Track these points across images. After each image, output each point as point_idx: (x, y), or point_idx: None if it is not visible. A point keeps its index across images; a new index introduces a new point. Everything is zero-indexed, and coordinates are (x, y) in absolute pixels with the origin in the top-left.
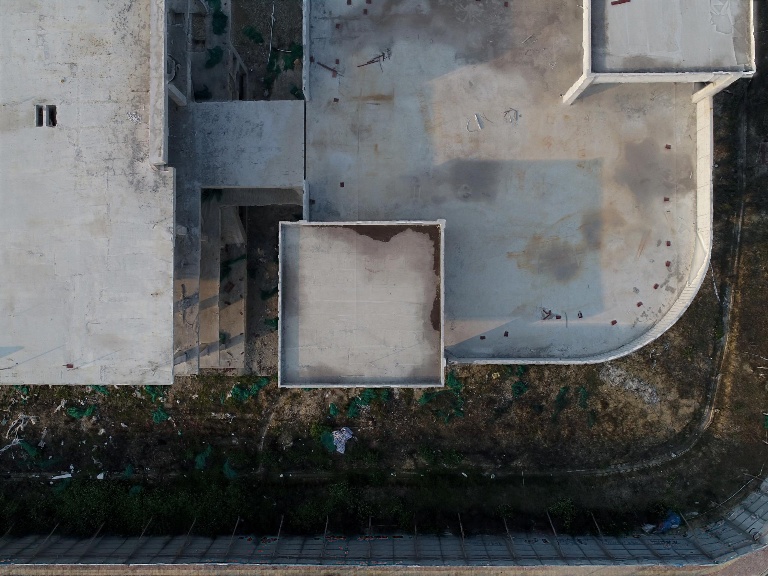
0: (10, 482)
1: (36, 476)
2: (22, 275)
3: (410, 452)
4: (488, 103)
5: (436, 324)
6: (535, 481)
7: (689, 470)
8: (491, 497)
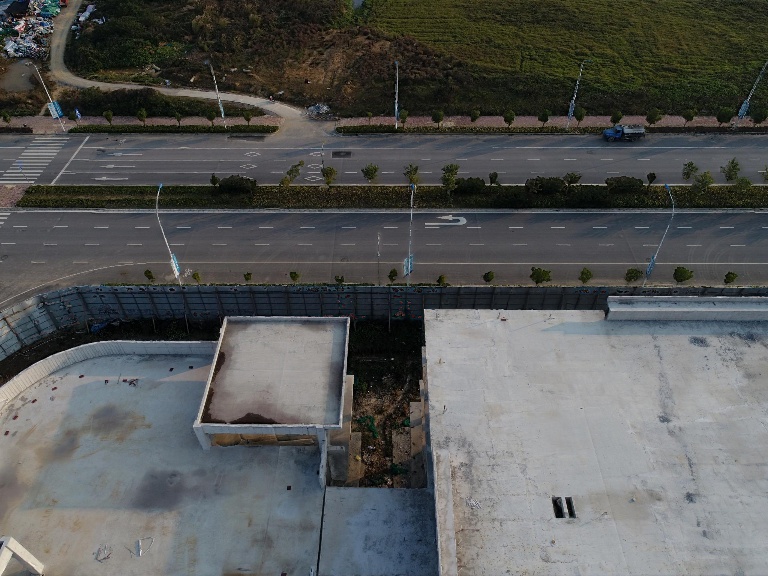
0: None
1: None
2: (555, 377)
3: None
4: (123, 568)
5: (222, 356)
6: None
7: None
8: None
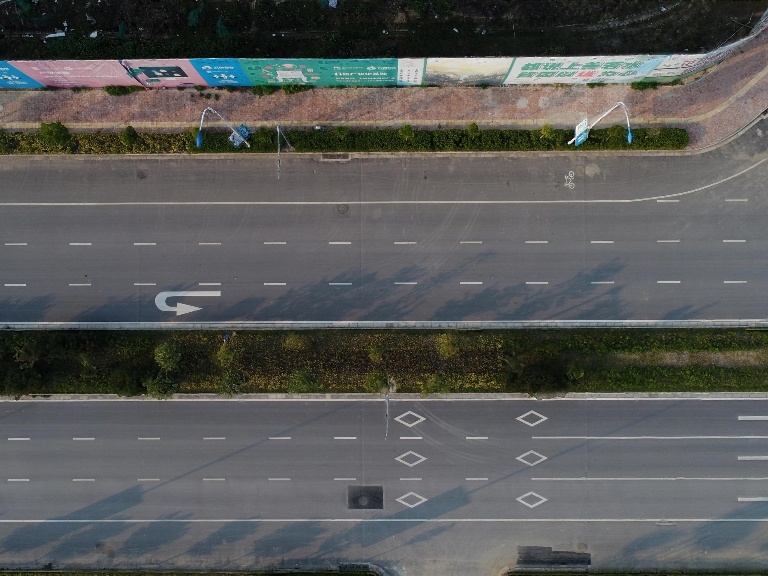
0: (4, 41)
1: (30, 36)
2: None
3: (402, 5)
4: None
5: None
6: (526, 34)
7: (679, 20)
8: (482, 46)
